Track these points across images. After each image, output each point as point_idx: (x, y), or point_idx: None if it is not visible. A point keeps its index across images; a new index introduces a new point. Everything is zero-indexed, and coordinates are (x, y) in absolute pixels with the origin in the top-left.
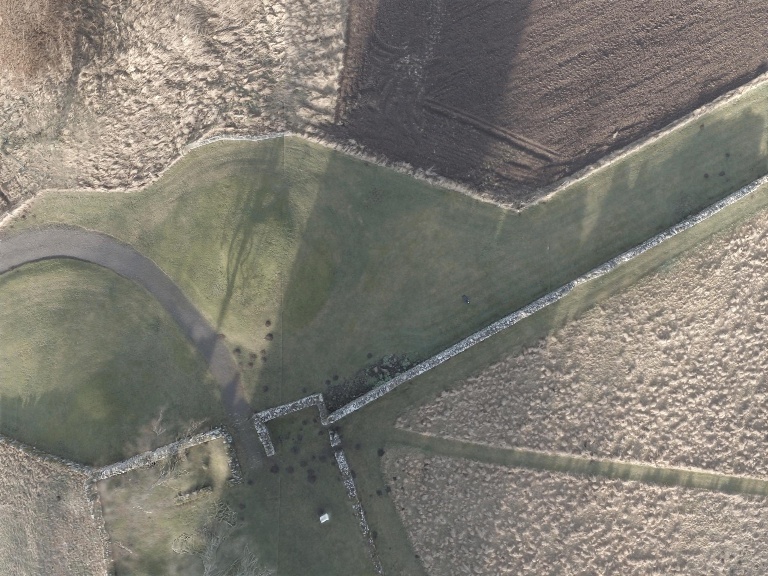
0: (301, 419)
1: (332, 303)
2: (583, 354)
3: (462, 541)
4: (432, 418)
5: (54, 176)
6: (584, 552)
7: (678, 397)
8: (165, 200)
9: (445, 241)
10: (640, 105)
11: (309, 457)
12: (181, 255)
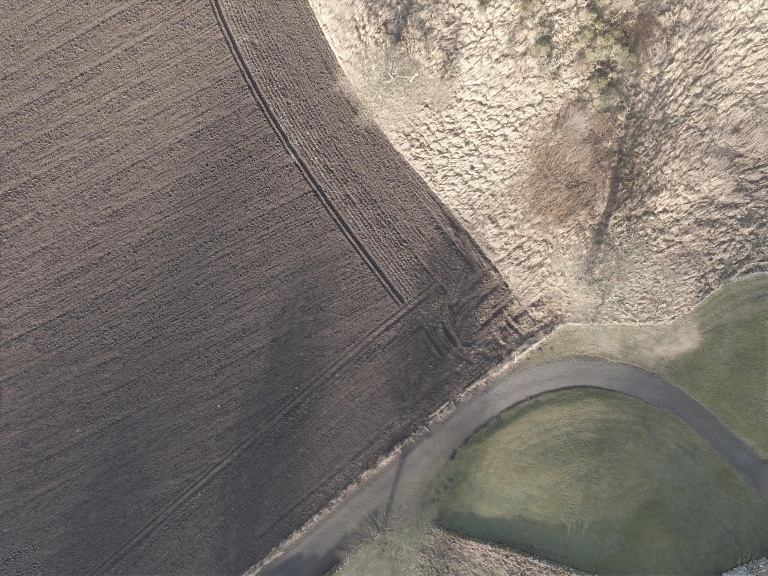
0: None
1: None
2: None
3: None
4: None
5: (574, 311)
6: None
7: None
8: (695, 332)
9: None
10: None
11: None
12: (718, 384)
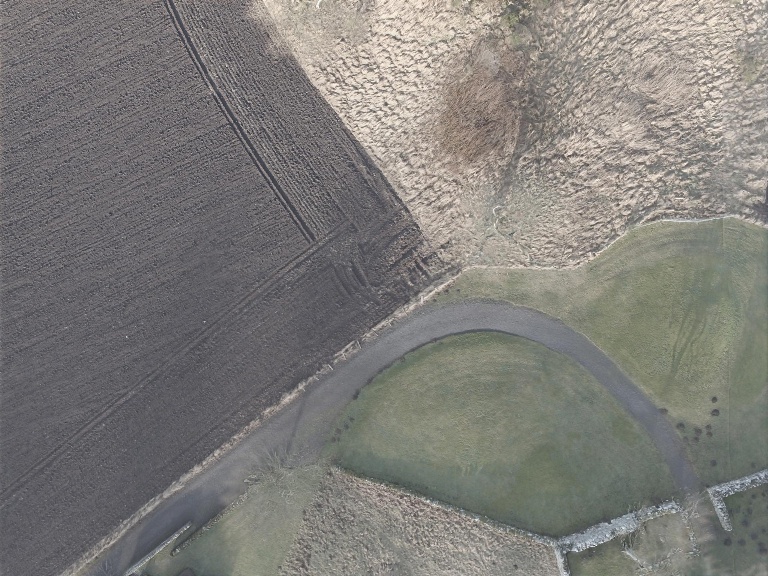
0: (750, 493)
1: None
2: None
3: None
4: None
5: None
6: None
7: None
8: (600, 278)
9: None
10: None
11: (760, 530)
12: (619, 332)
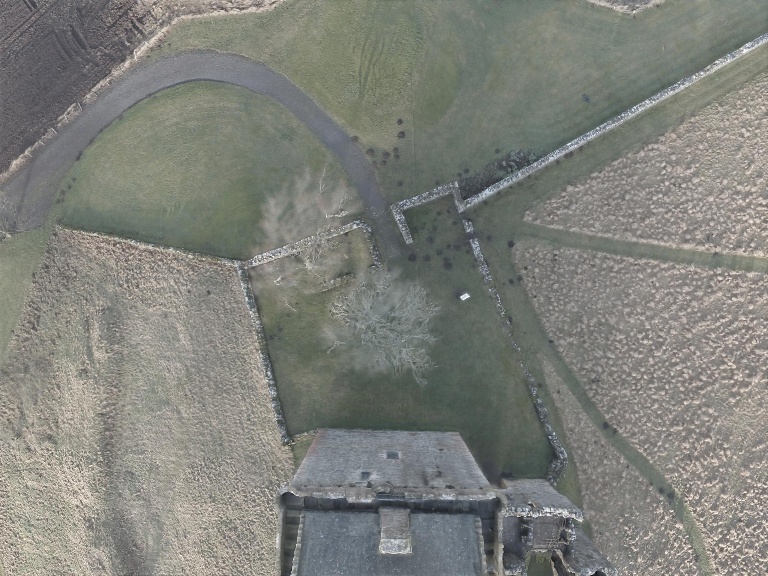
0: (435, 210)
1: (460, 101)
2: (702, 150)
3: (593, 328)
4: (559, 211)
5: (188, 4)
6: (712, 341)
7: None
8: (295, 16)
9: (563, 44)
10: None
11: (444, 246)
12: (313, 65)
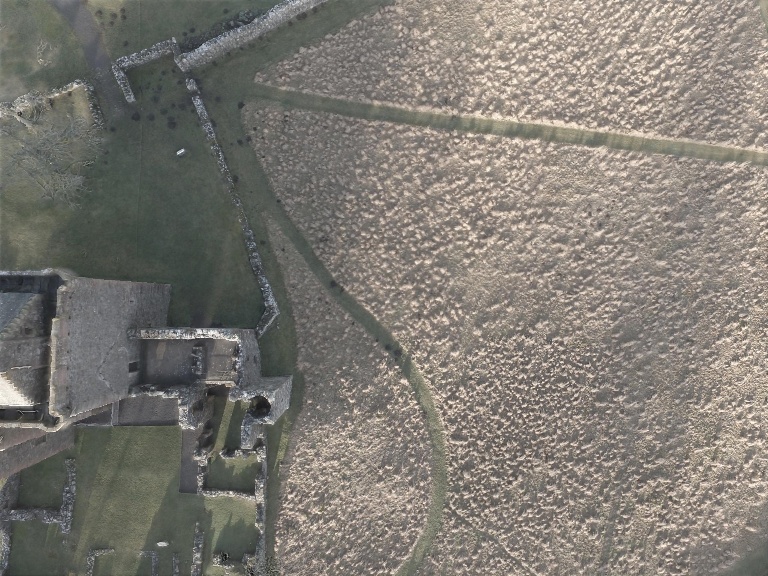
0: (160, 70)
1: None
2: (440, 13)
3: (323, 188)
4: (290, 72)
5: None
6: (447, 202)
7: (538, 53)
8: None
9: None
10: None
11: (169, 105)
12: None
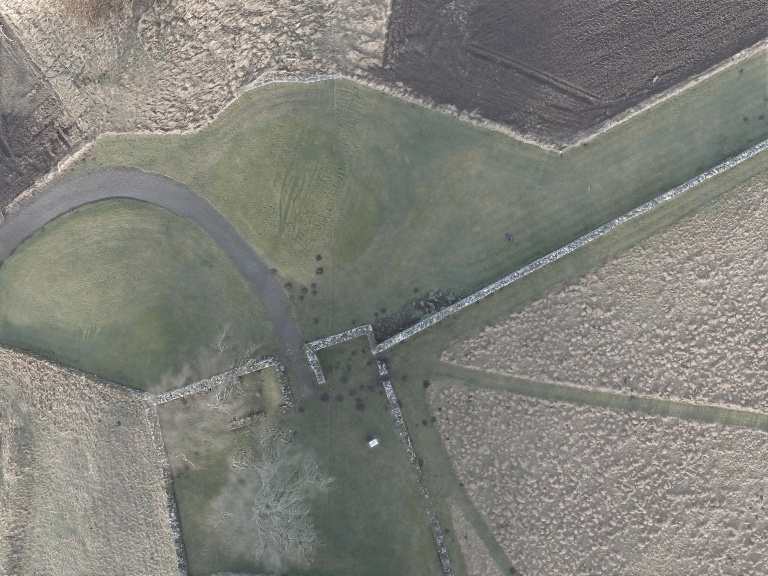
0: (350, 350)
1: (380, 239)
2: (623, 292)
3: (505, 471)
4: (476, 352)
5: (113, 120)
6: (624, 485)
7: (717, 336)
8: (219, 141)
9: (489, 181)
10: (680, 50)
11: (358, 386)
12: (235, 193)
